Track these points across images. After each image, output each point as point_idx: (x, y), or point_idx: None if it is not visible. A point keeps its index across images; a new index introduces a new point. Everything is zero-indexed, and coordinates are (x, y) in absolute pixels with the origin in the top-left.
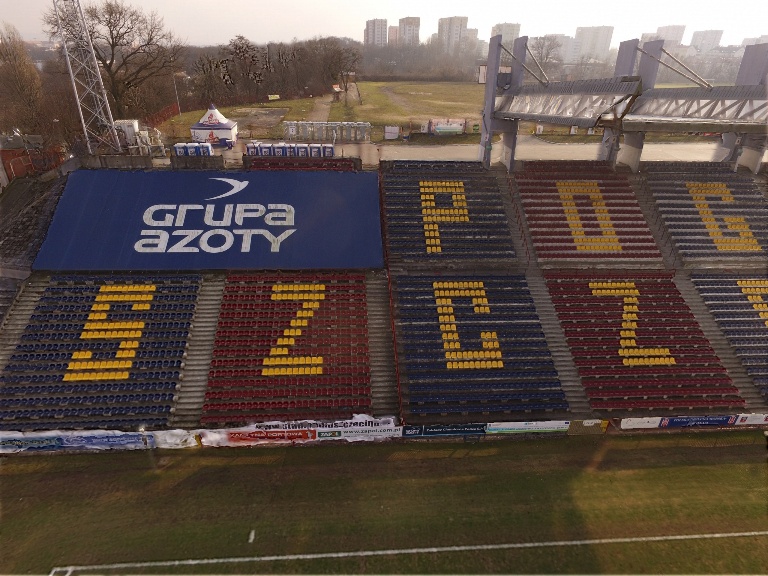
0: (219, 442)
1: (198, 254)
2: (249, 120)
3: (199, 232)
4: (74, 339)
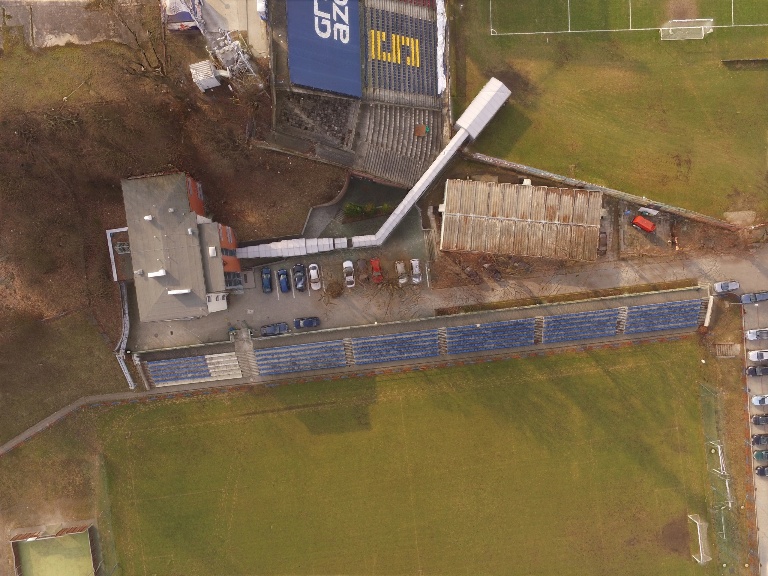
0: (442, 1)
1: (349, 7)
2: (51, 15)
3: (334, 4)
4: (400, 67)
